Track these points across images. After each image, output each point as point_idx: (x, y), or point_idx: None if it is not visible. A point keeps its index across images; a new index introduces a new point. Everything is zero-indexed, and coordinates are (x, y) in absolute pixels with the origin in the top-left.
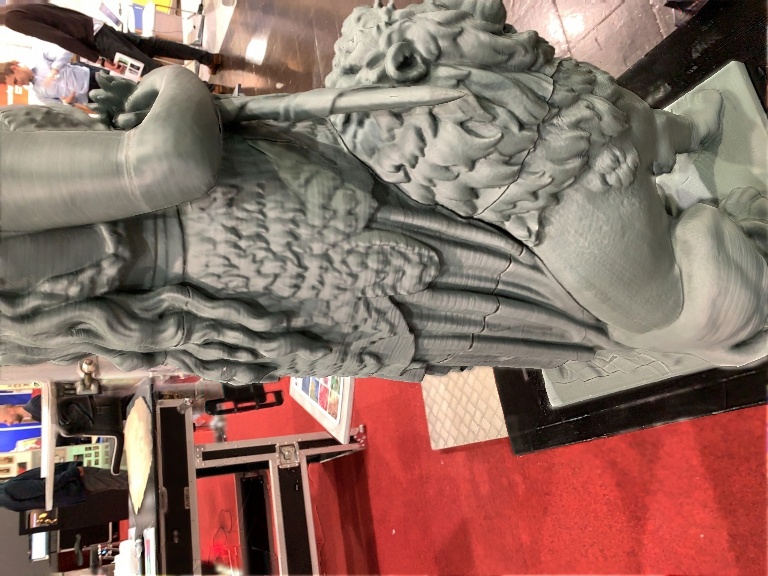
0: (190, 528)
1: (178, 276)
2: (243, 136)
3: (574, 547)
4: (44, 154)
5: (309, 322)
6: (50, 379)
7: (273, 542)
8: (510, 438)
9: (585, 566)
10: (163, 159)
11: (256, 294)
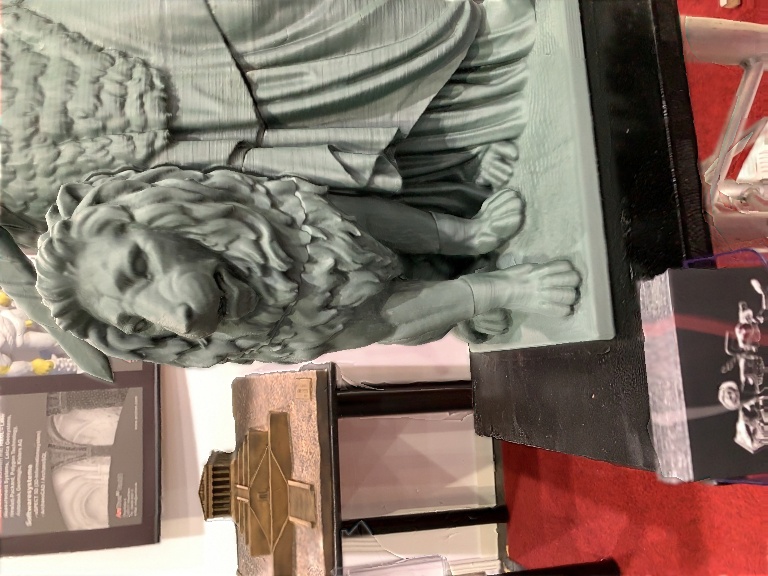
0: None
1: None
2: None
3: None
4: None
5: None
6: None
7: None
8: None
9: None
10: None
11: None
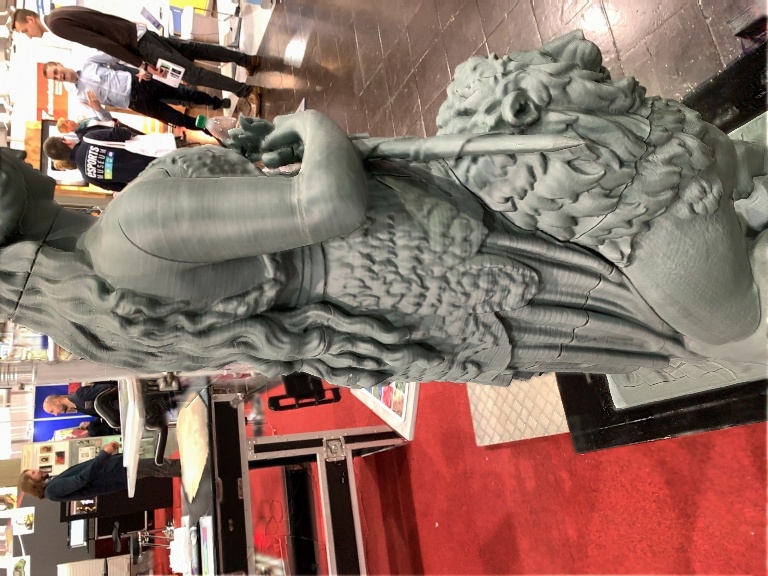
0: (244, 517)
1: (319, 296)
2: (372, 172)
3: (622, 542)
4: (233, 199)
5: (426, 335)
6: (136, 376)
7: (321, 532)
8: (572, 437)
9: (633, 561)
10: (329, 202)
11: (385, 311)
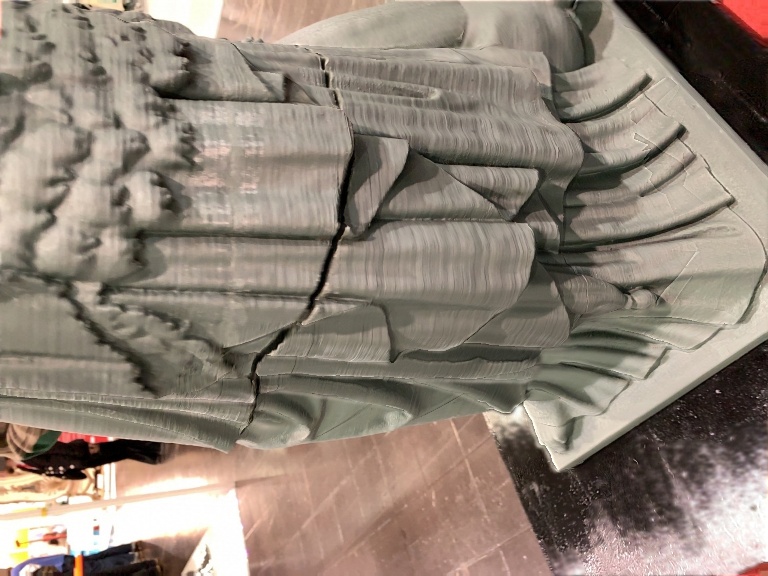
0: None
1: None
2: None
3: None
4: None
5: None
6: None
7: None
8: None
9: None
10: None
11: None
